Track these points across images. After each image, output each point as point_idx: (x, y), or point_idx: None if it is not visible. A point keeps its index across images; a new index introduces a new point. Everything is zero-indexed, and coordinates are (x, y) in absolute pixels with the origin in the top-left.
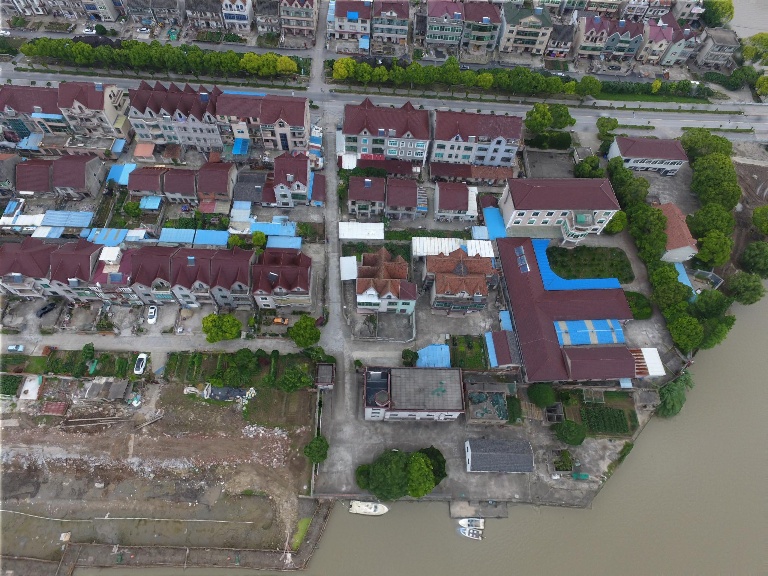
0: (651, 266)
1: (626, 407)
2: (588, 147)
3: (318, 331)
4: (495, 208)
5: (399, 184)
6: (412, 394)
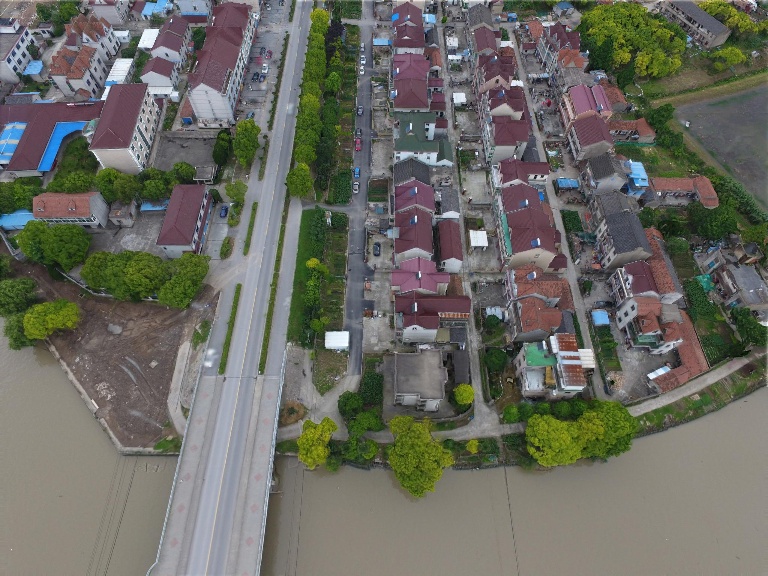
0: None
1: None
2: None
3: (65, 14)
4: None
5: (169, 39)
6: None
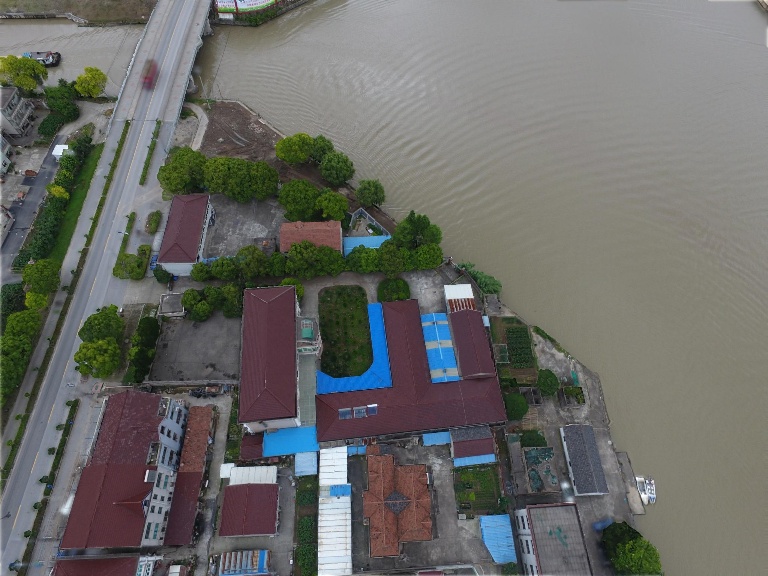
0: (355, 268)
1: (500, 324)
2: (161, 297)
3: None
4: (264, 439)
5: None
6: (573, 574)
